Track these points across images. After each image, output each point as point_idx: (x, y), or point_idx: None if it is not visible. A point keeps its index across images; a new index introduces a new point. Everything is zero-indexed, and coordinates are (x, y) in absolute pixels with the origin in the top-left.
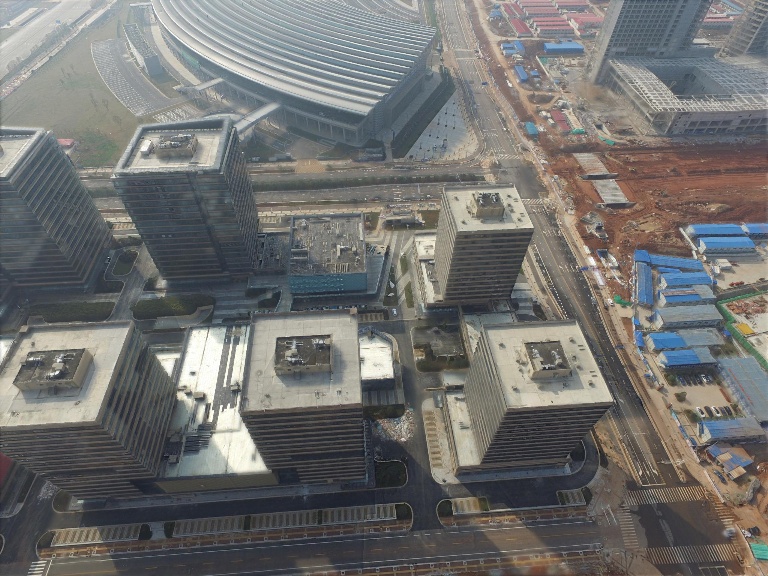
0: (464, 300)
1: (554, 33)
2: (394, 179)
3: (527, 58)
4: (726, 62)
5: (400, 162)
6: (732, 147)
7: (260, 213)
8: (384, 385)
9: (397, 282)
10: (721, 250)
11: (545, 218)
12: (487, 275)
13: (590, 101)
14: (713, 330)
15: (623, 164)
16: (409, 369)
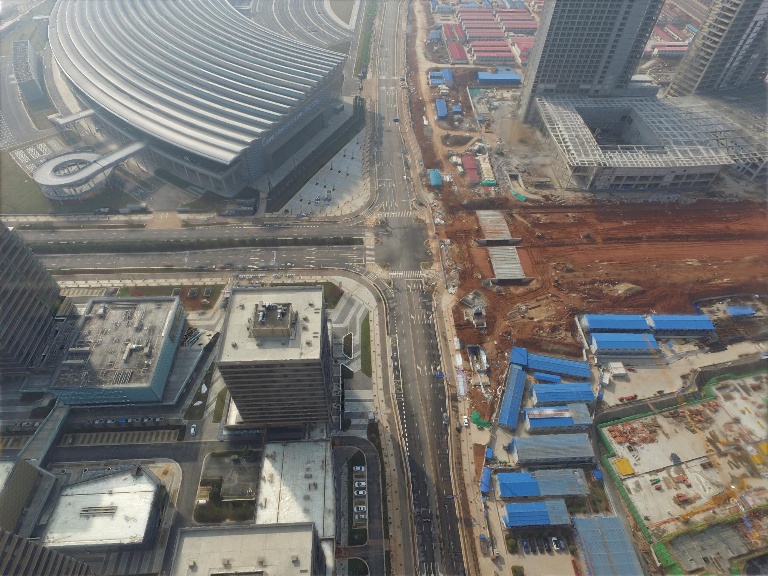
0: (271, 422)
1: (492, 60)
2: (256, 241)
3: (455, 89)
4: (669, 103)
5: (272, 217)
6: (663, 207)
7: (83, 282)
8: (135, 547)
9: (212, 385)
10: (617, 351)
11: (419, 298)
12: (285, 401)
13: (512, 144)
14: (579, 472)
15: (531, 226)
16: (183, 517)
